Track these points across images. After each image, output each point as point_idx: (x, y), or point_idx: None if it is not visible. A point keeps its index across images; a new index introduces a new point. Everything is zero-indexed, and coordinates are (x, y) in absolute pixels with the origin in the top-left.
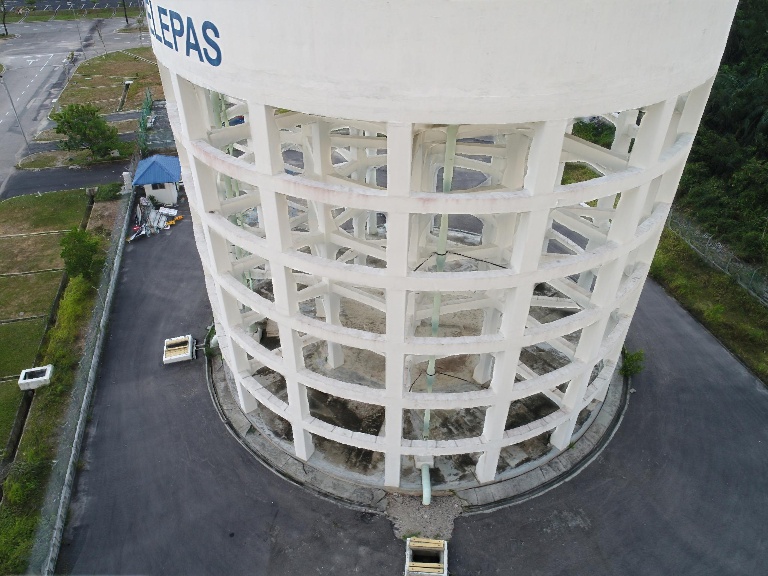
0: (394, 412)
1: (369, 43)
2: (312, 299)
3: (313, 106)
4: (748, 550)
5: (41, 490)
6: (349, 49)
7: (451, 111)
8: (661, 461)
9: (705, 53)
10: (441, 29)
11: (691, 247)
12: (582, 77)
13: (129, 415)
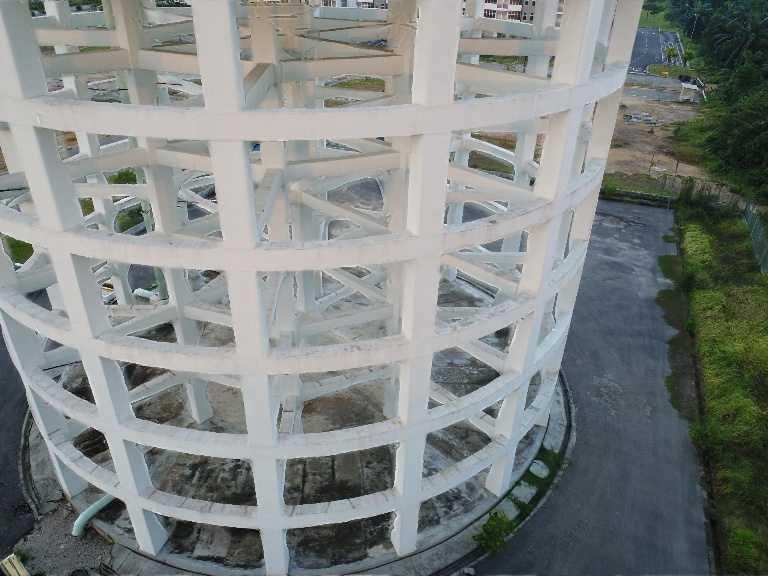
0: None
1: None
2: None
3: None
4: None
5: None
6: None
7: None
8: None
9: None
10: None
11: None
12: None
13: None
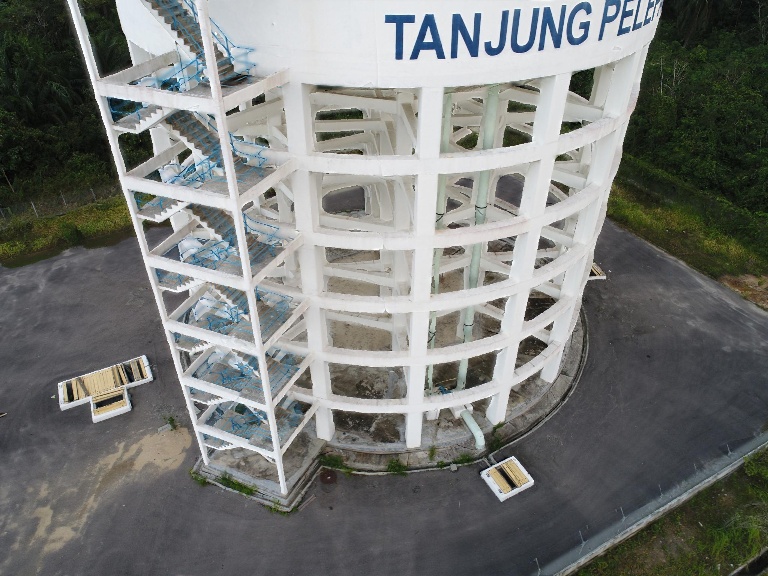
0: None
1: None
2: (374, 378)
3: None
4: (498, 187)
5: (730, 513)
6: None
7: None
8: (460, 203)
9: None
10: None
11: None
12: None
13: (613, 481)
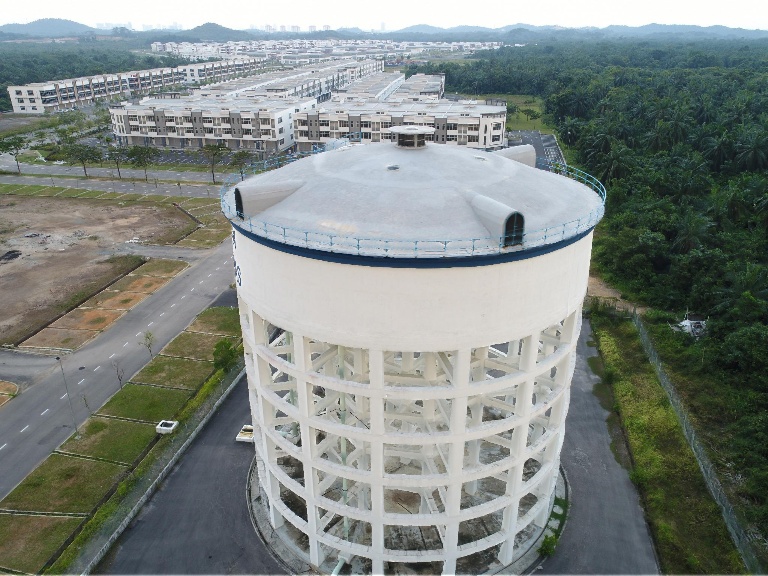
0: (311, 506)
1: (284, 295)
2: None
3: (266, 317)
4: None
5: (135, 493)
6: (277, 296)
7: (319, 334)
8: None
9: (493, 326)
10: (311, 296)
11: (700, 470)
12: (386, 331)
13: (200, 466)
